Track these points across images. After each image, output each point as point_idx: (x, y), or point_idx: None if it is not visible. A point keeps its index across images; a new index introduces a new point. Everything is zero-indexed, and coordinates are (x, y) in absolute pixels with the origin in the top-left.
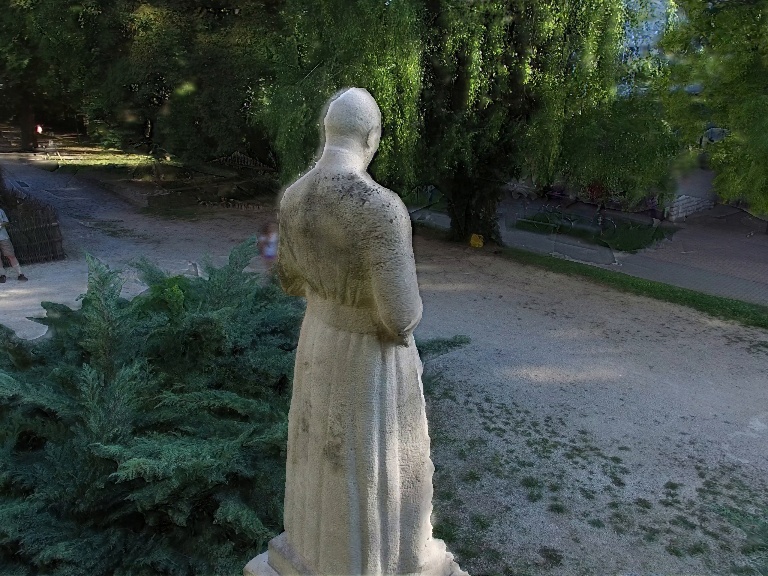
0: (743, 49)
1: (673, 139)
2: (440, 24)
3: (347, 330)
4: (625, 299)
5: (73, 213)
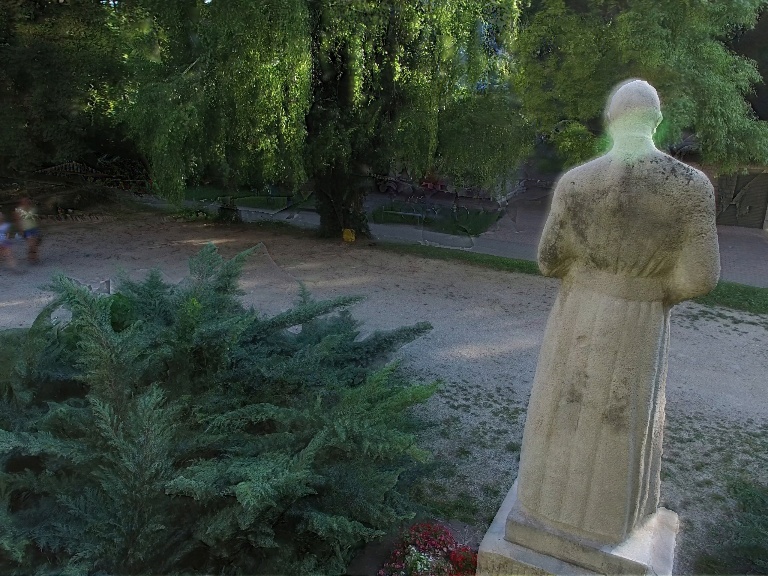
0: (592, 51)
1: (531, 130)
2: (324, 21)
3: (637, 300)
4: (503, 277)
5: None
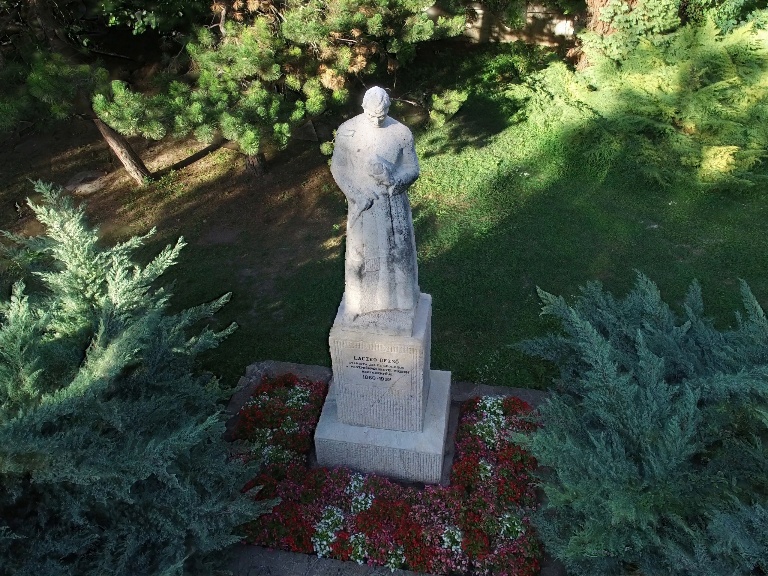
0: None
1: None
2: None
3: None
4: None
5: None
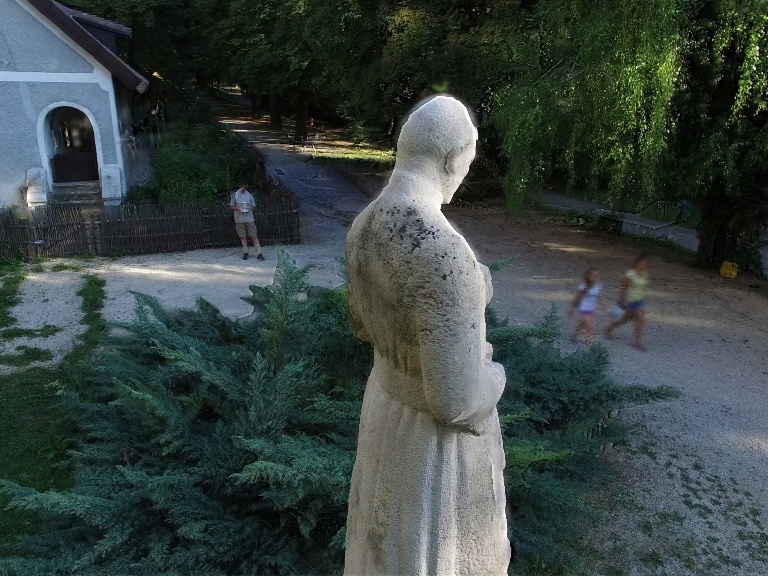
0: None
1: None
2: (707, 16)
3: (399, 400)
4: None
5: (318, 201)
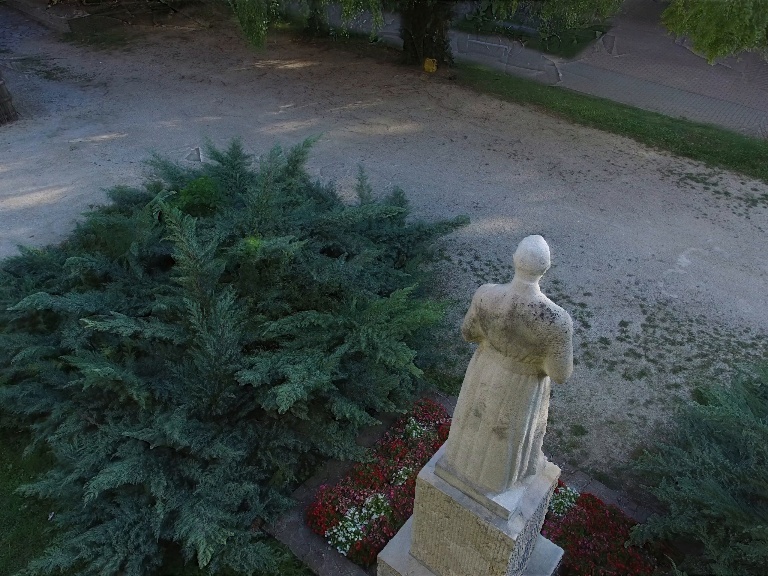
0: None
1: None
2: None
3: (519, 373)
4: (574, 132)
5: None
